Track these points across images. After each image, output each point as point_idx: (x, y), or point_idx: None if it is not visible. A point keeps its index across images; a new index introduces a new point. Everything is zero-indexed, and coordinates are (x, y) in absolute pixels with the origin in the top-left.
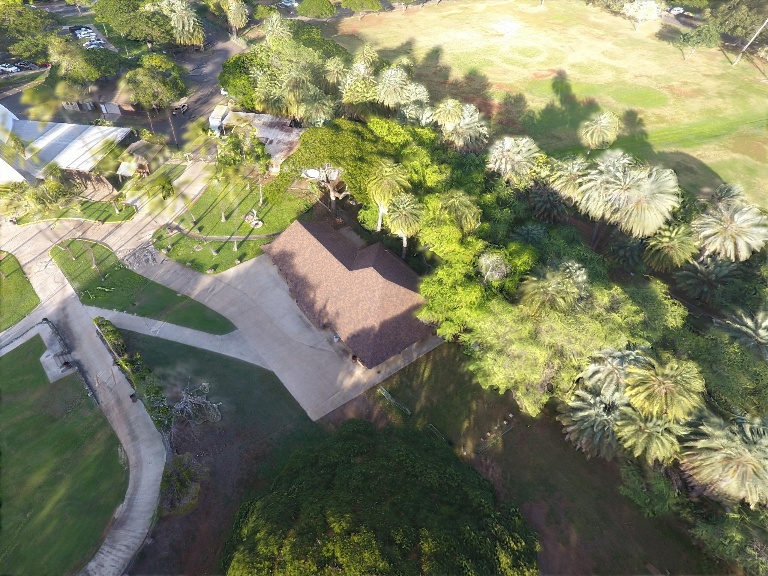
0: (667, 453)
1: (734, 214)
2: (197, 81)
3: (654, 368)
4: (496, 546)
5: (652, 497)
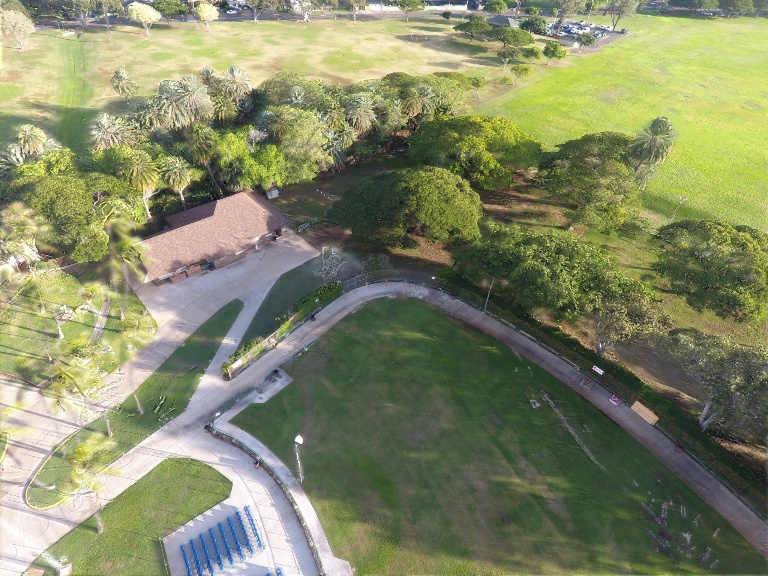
0: None
1: (233, 73)
2: None
3: (326, 114)
4: None
5: None
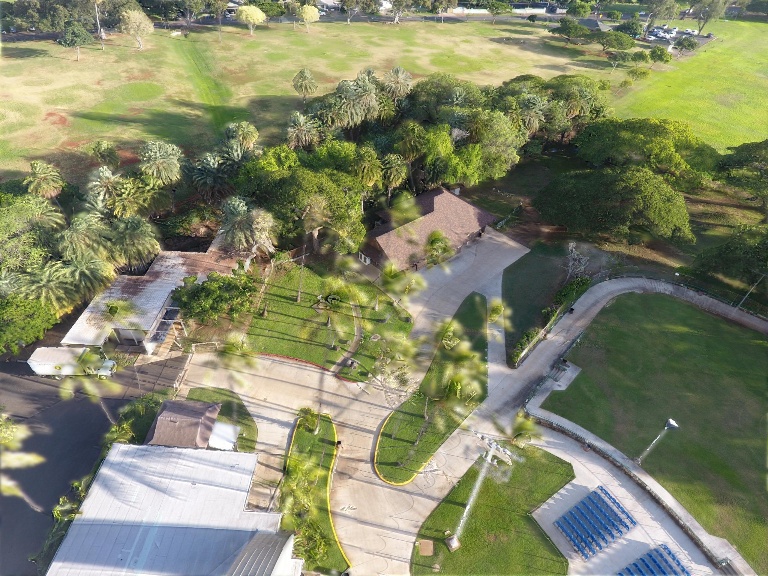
0: None
1: (398, 74)
2: None
3: (506, 114)
4: None
5: None
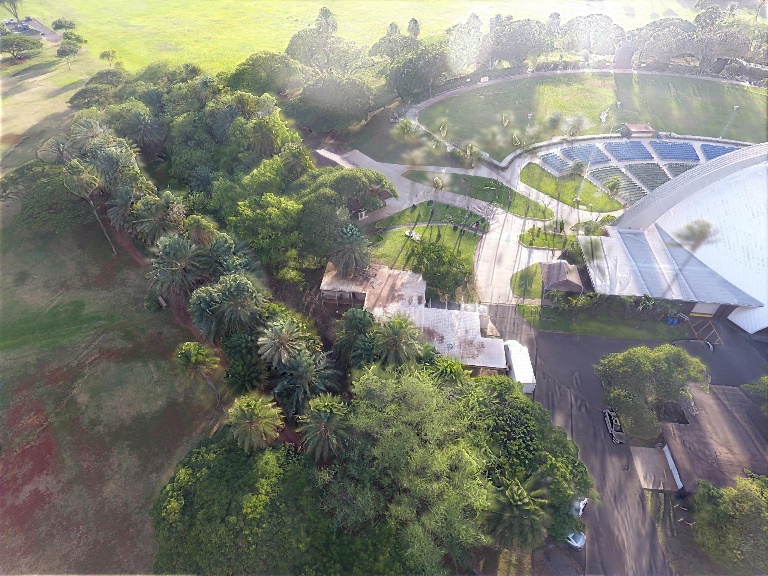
0: None
1: None
2: None
3: None
4: None
5: None
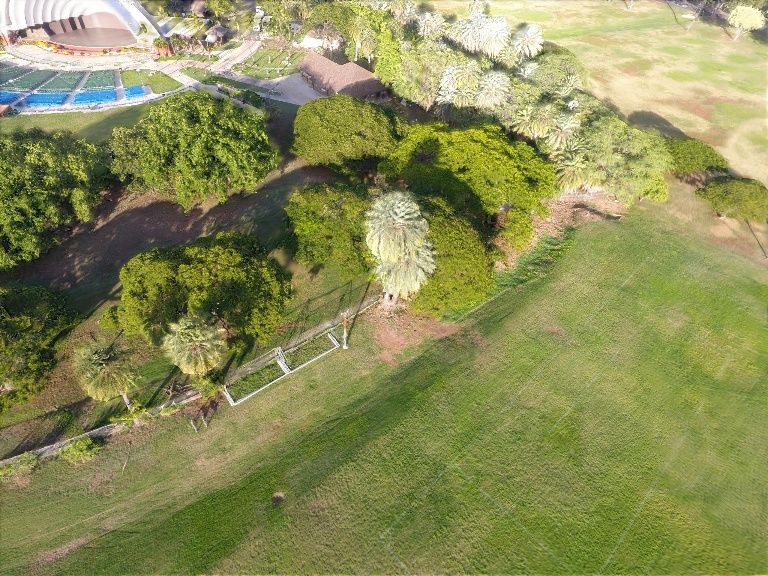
0: (470, 102)
1: None
2: (238, 6)
3: None
4: (395, 116)
5: (463, 119)
